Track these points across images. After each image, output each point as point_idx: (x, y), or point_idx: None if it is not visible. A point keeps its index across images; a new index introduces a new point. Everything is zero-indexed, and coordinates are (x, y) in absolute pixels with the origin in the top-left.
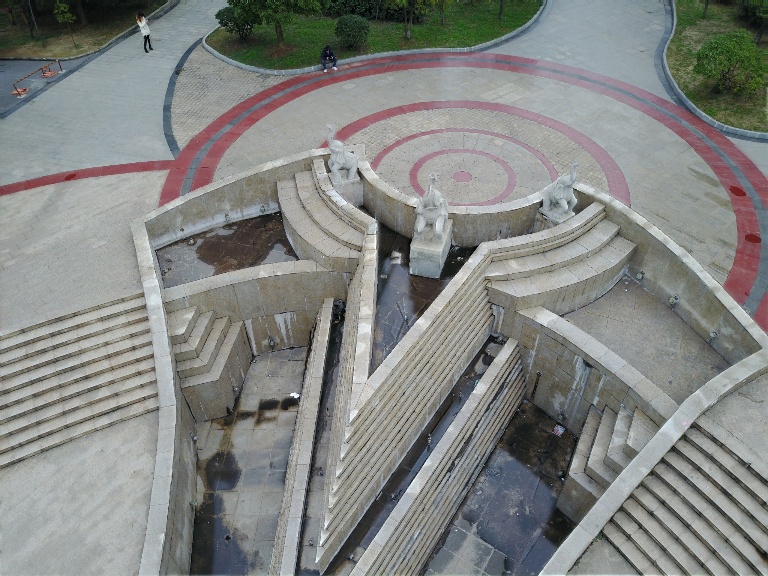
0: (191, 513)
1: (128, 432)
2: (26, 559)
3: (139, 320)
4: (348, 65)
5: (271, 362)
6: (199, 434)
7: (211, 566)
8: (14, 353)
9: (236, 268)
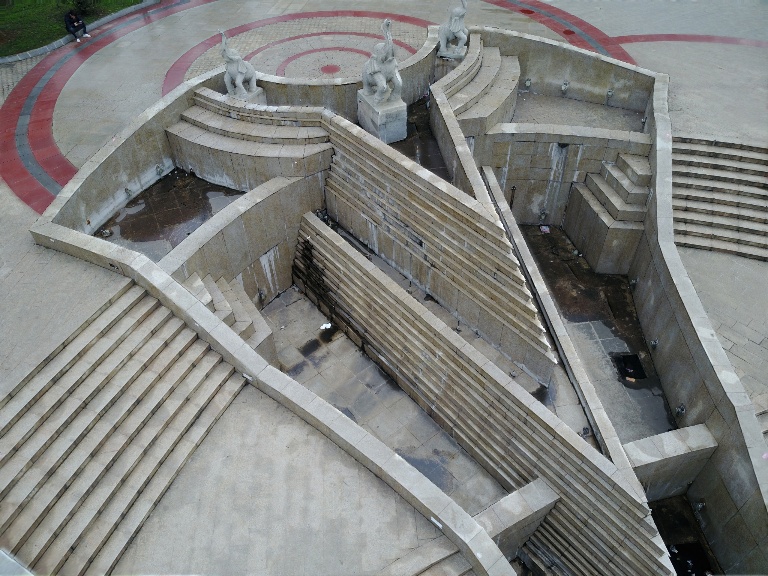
0: None
1: (236, 425)
2: None
3: (147, 314)
4: (98, 29)
5: (271, 317)
6: None
7: None
8: (22, 425)
9: (190, 229)
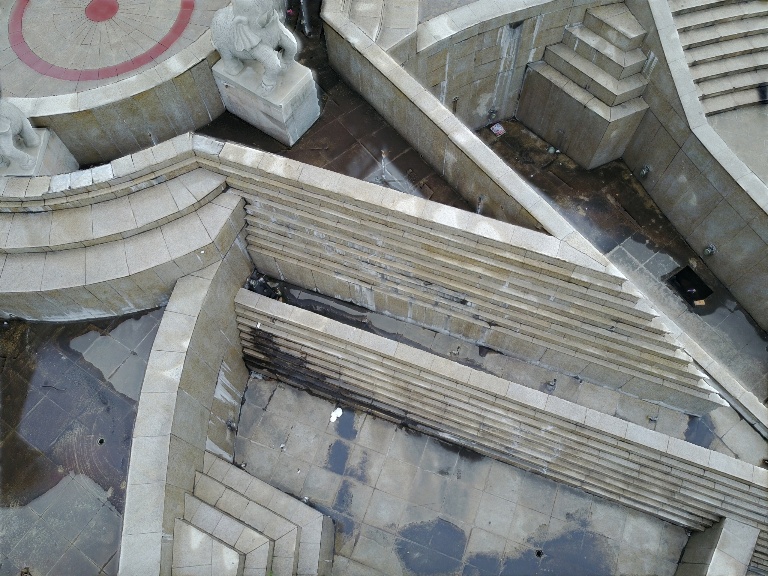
0: None
1: None
2: None
3: None
4: None
5: (257, 439)
6: None
7: None
8: None
9: (97, 431)
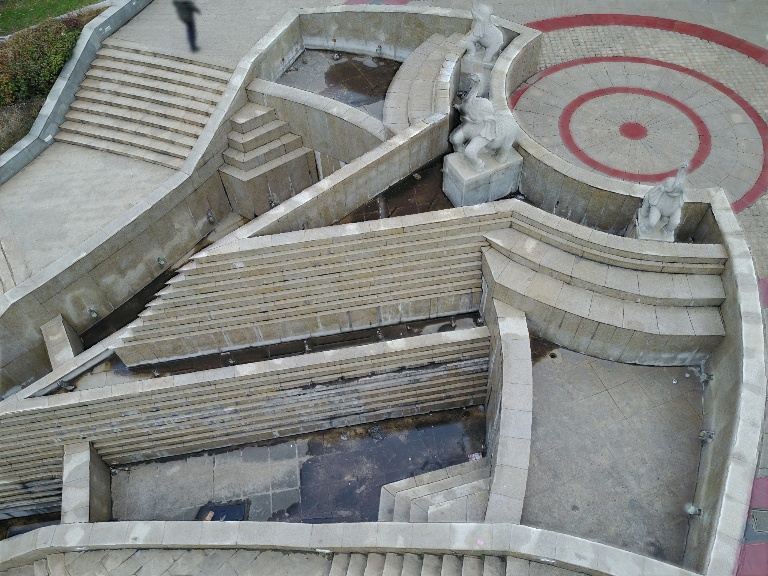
0: (157, 267)
1: (157, 175)
2: (33, 210)
3: None
4: None
5: None
6: (226, 221)
7: (135, 312)
8: (139, 68)
9: (339, 98)
